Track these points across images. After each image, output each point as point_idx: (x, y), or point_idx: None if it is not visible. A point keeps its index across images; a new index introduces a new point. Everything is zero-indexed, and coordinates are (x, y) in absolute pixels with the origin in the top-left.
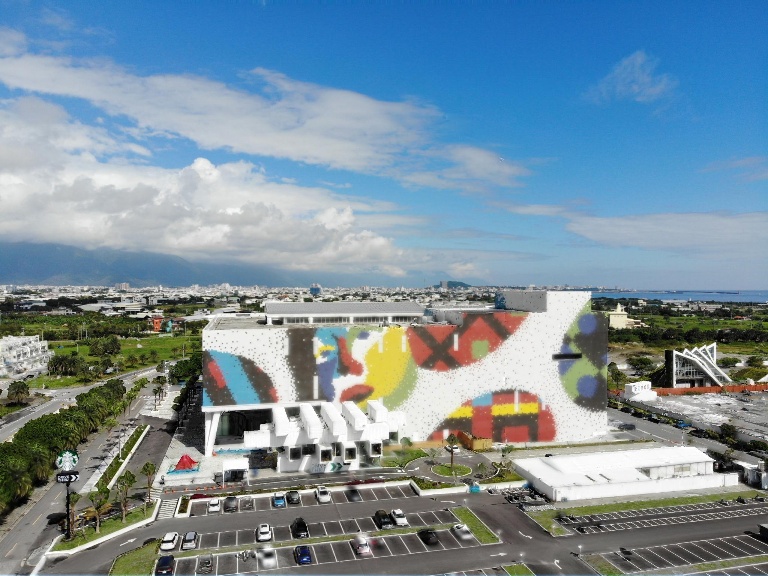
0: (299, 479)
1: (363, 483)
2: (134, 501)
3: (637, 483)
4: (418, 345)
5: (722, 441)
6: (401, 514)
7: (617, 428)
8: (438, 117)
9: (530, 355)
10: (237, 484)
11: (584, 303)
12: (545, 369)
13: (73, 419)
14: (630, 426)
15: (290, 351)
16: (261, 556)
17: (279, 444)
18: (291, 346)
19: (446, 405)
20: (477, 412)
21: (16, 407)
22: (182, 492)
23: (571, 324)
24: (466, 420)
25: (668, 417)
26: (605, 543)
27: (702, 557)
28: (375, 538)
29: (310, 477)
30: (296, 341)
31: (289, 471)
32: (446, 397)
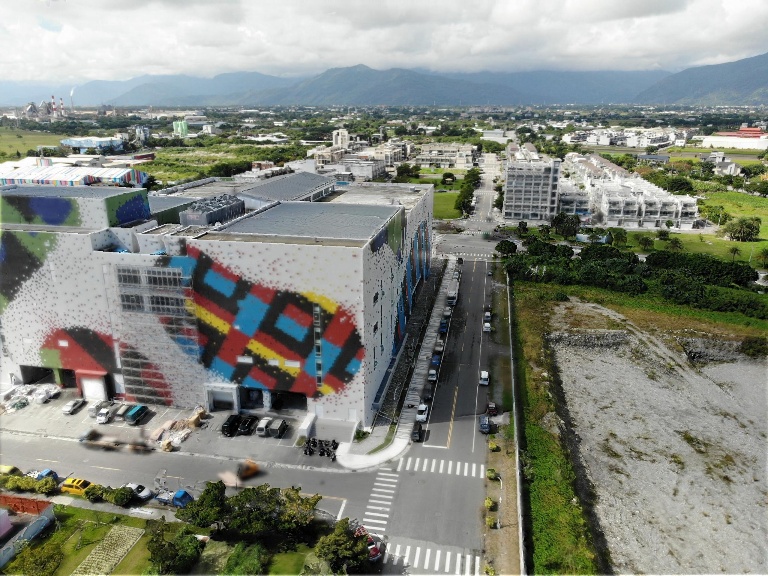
0: None
1: None
2: None
3: None
4: None
5: None
6: None
7: None
8: None
9: None
10: None
11: None
12: None
13: None
14: None
15: None
16: None
17: None
18: None
19: None
20: None
21: None
22: None
23: None
24: None
25: None
26: None
27: None
28: None
29: None
30: None
31: None
32: None
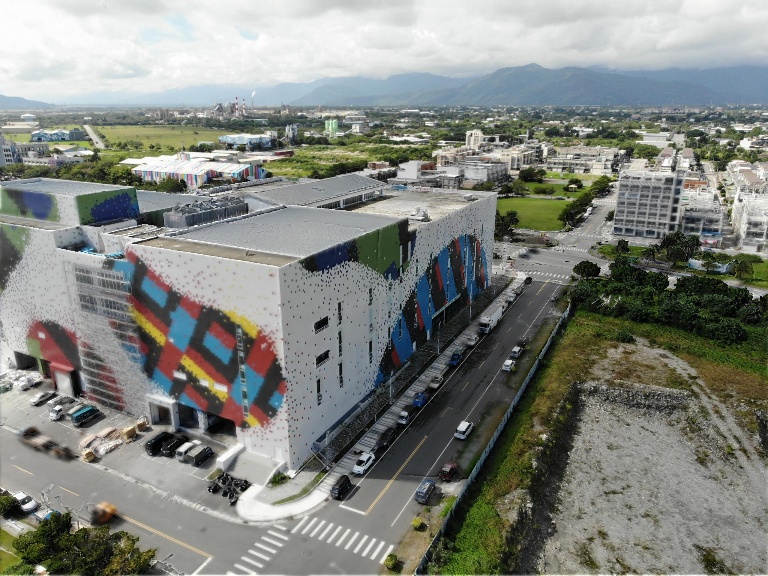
0: None
1: None
2: None
3: None
4: None
5: None
6: None
7: None
8: (114, 7)
9: None
10: None
11: None
12: None
13: None
14: None
15: None
16: None
17: None
18: None
19: None
20: None
21: None
22: None
23: None
24: None
25: None
26: None
27: None
28: None
29: None
30: None
31: None
32: None
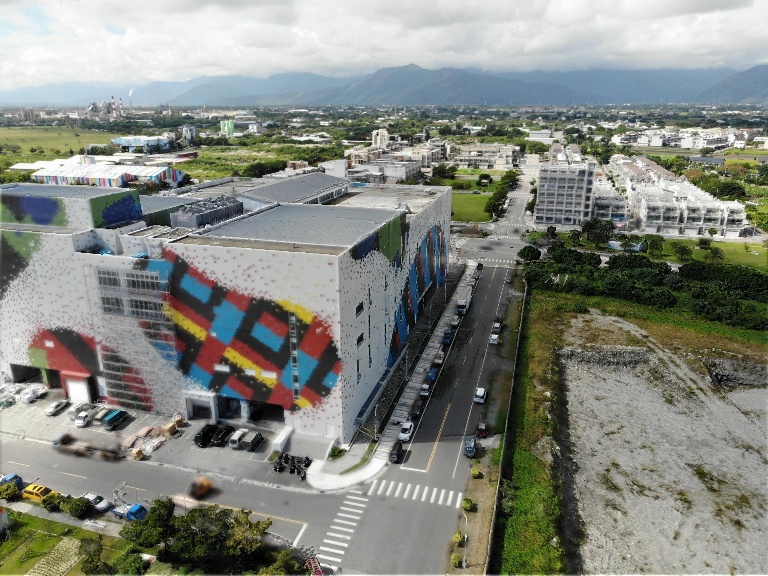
0: None
1: None
2: None
3: None
4: None
5: None
6: None
7: None
8: None
9: None
10: None
11: None
12: None
13: None
14: None
15: None
16: None
17: None
18: None
19: None
20: None
21: None
22: None
23: None
24: None
25: None
26: None
27: None
28: None
29: None
30: None
31: None
32: None
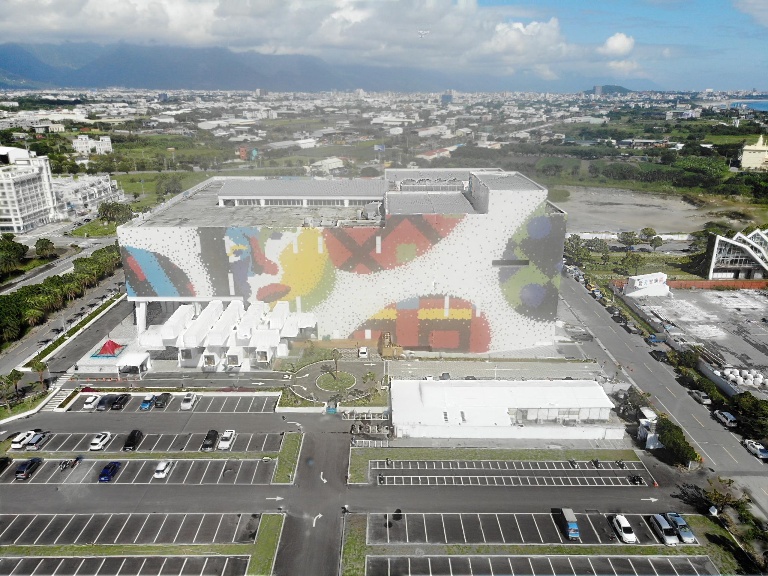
0: (187, 378)
1: (235, 391)
2: (40, 387)
3: (494, 428)
4: (336, 246)
5: (678, 369)
6: (228, 437)
7: (569, 338)
8: None
9: (465, 260)
10: (131, 378)
11: (537, 204)
12: (482, 275)
13: (45, 292)
14: (586, 337)
15: (202, 249)
16: (79, 467)
17: (171, 345)
18: (203, 244)
19: (368, 307)
20: (402, 315)
21: (44, 261)
22: (84, 381)
23: (518, 228)
24: (390, 322)
25: (650, 326)
26: (389, 500)
27: (467, 536)
28: (187, 460)
29: (199, 376)
30: (207, 240)
31: (188, 366)
32: (368, 299)
